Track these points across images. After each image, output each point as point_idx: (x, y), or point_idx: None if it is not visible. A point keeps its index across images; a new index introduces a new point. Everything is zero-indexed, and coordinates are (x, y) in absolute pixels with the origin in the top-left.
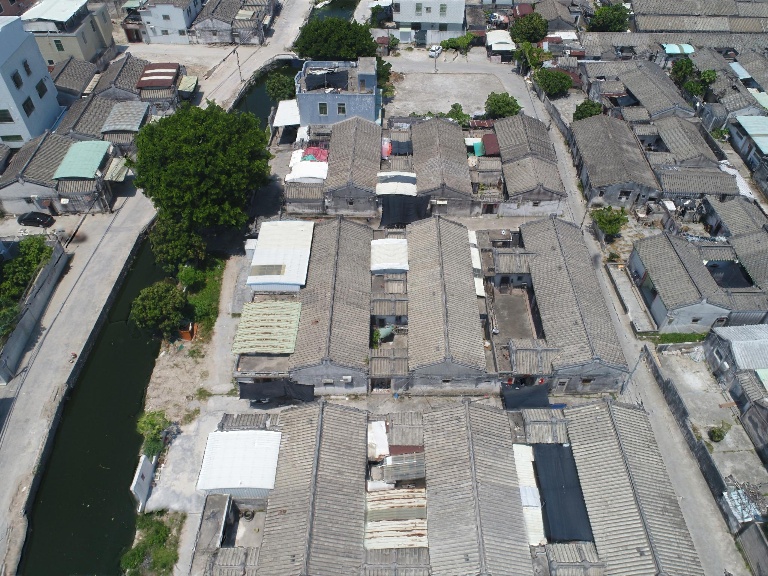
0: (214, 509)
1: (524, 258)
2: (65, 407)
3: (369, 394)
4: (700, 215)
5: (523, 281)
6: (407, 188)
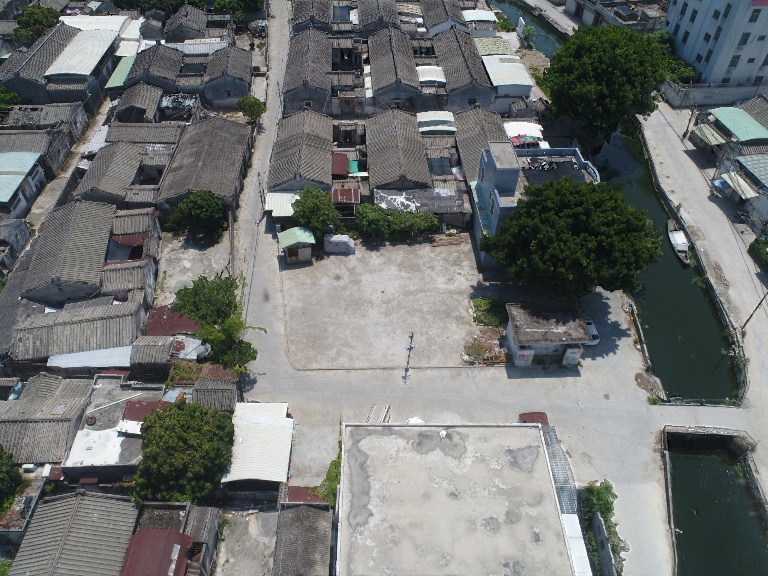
0: None
1: None
2: None
3: None
4: None
5: None
6: (426, 117)
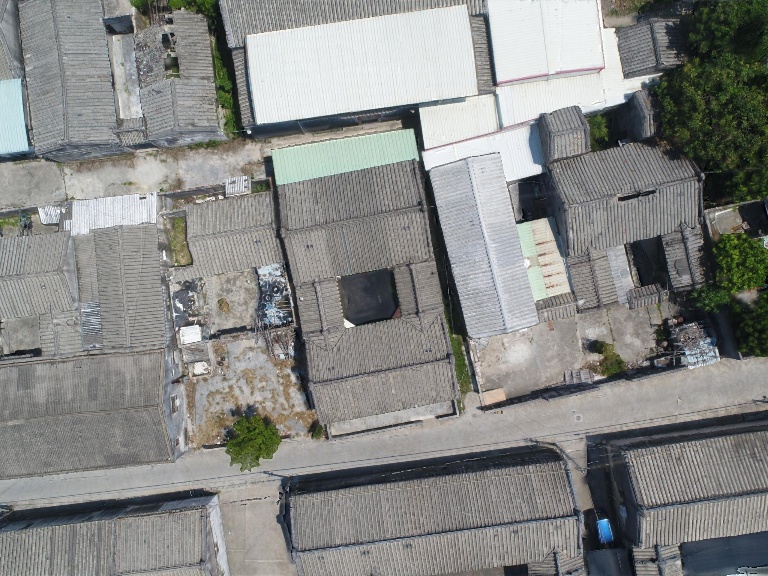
0: None
1: None
2: None
3: None
4: None
5: None
6: None
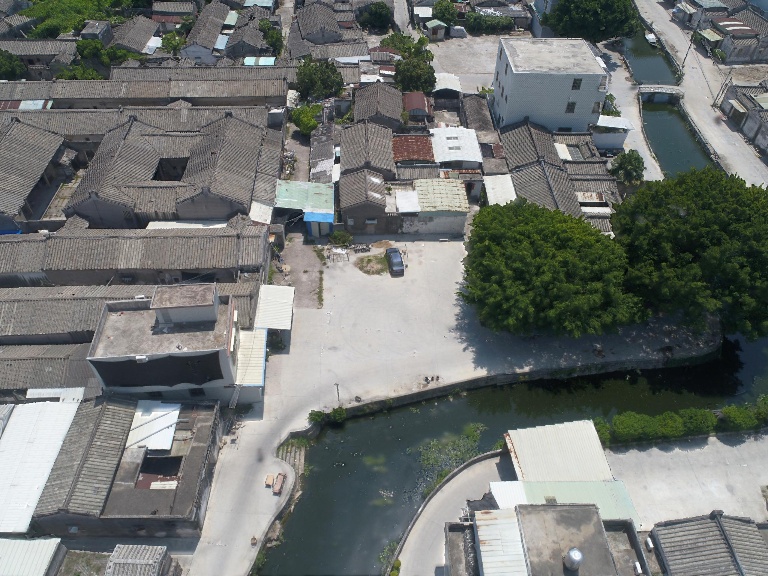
0: None
1: None
2: None
3: None
4: None
5: None
6: None
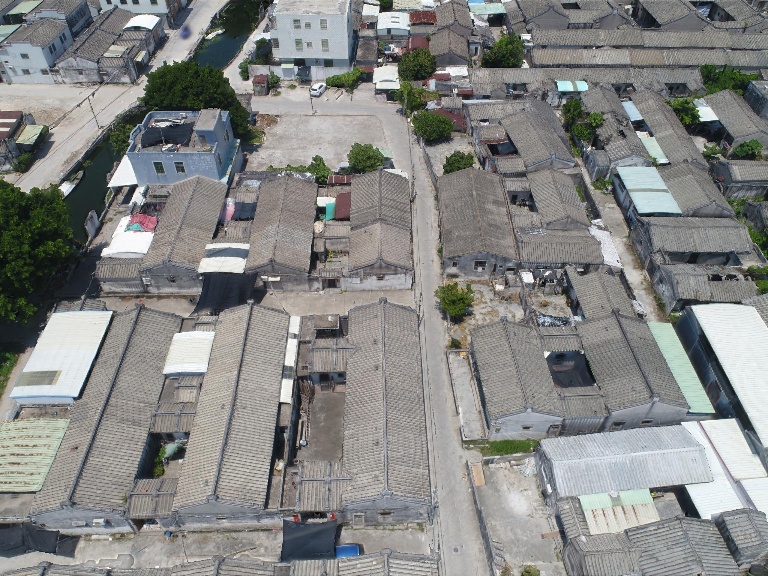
0: None
1: (342, 353)
2: None
3: (137, 532)
4: (561, 287)
5: (345, 378)
6: (234, 264)
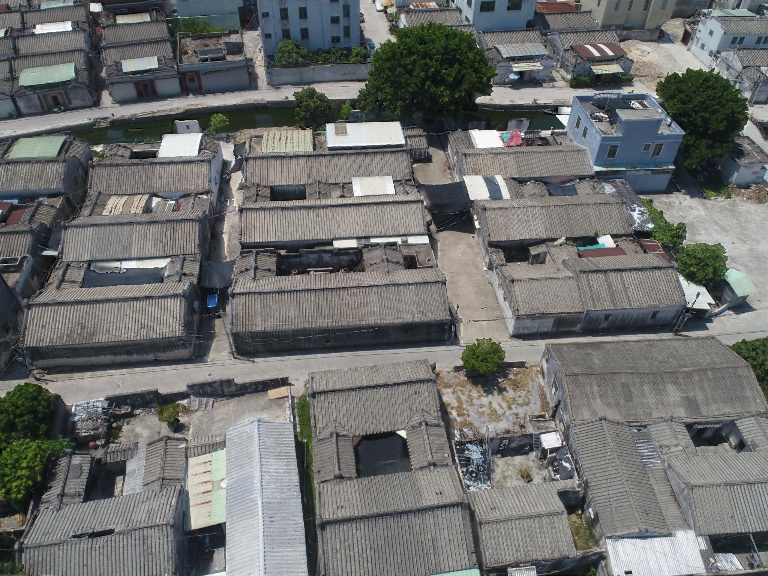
0: (157, 146)
1: (381, 266)
2: (255, 108)
3: None
4: None
5: None
6: (480, 192)
